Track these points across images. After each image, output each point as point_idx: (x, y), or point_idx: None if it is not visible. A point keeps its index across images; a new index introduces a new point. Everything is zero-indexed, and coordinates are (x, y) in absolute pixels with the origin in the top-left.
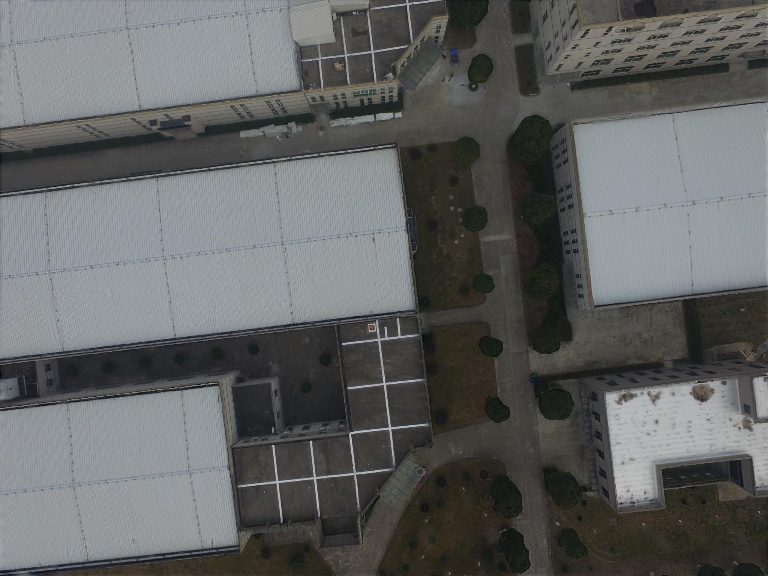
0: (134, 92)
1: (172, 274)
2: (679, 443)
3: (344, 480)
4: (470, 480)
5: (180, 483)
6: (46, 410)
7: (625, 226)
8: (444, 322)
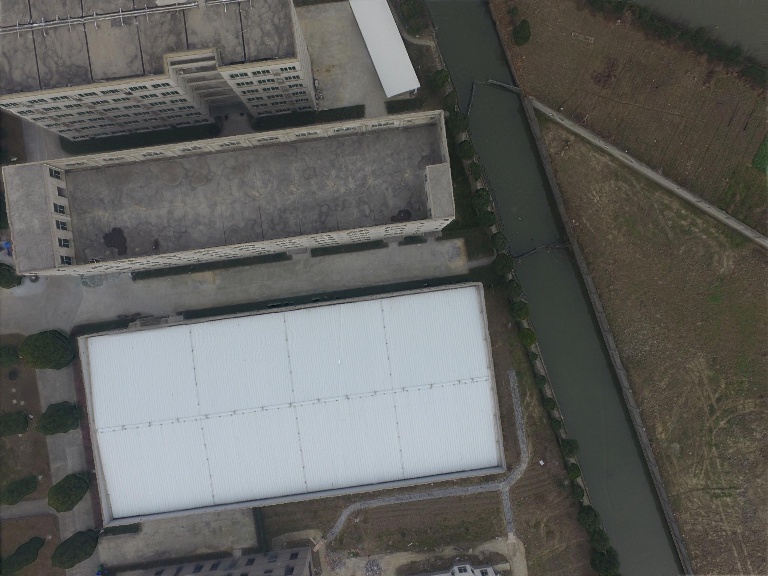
0: None
1: None
2: None
3: None
4: None
5: None
6: None
7: (139, 440)
8: (11, 515)
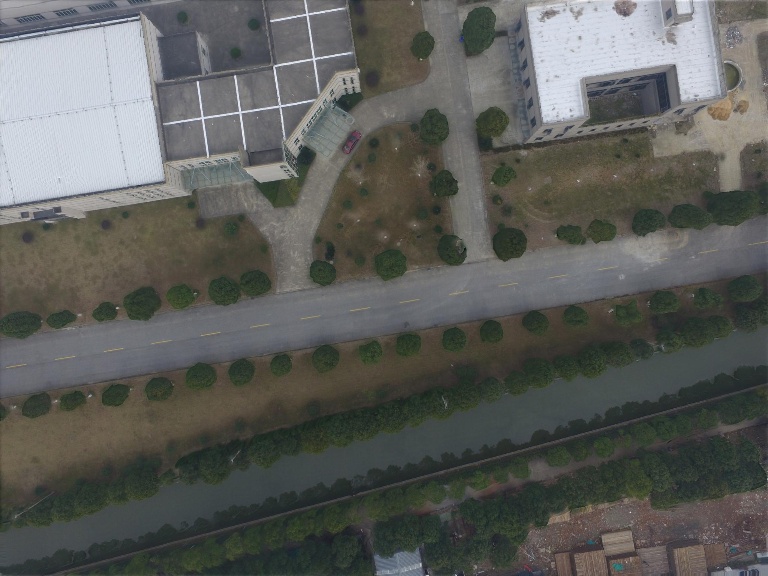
0: None
1: None
2: (603, 58)
3: (269, 113)
4: (403, 141)
5: (104, 117)
6: None
7: None
8: None
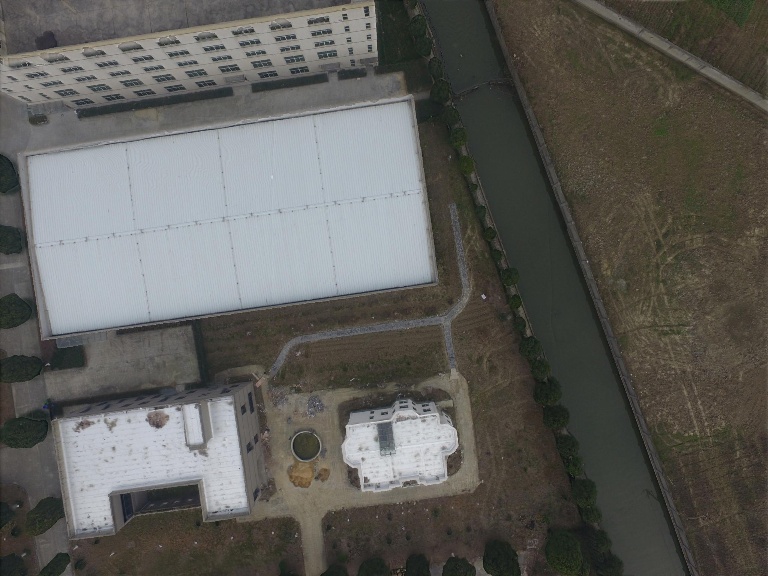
0: None
1: None
2: (136, 469)
3: None
4: None
5: None
6: None
7: (77, 256)
8: None
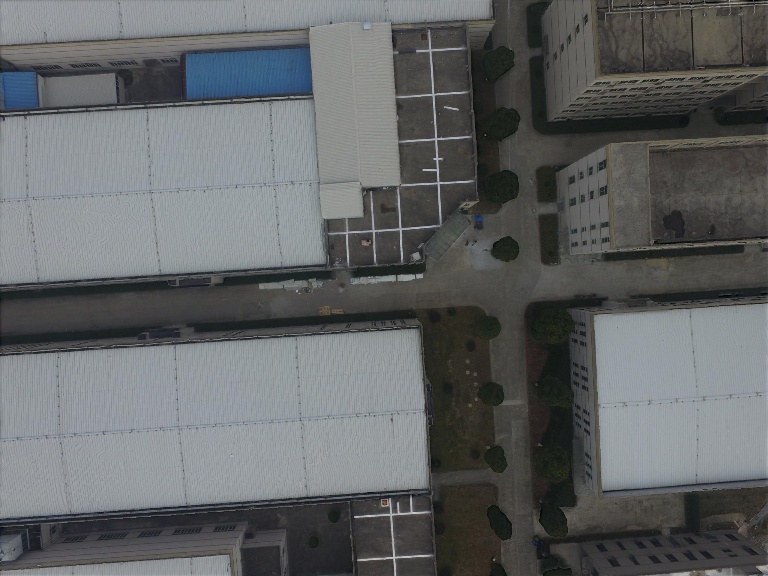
0: (154, 253)
1: (186, 444)
2: None
3: None
4: None
5: None
6: (50, 572)
7: (637, 417)
8: (453, 483)
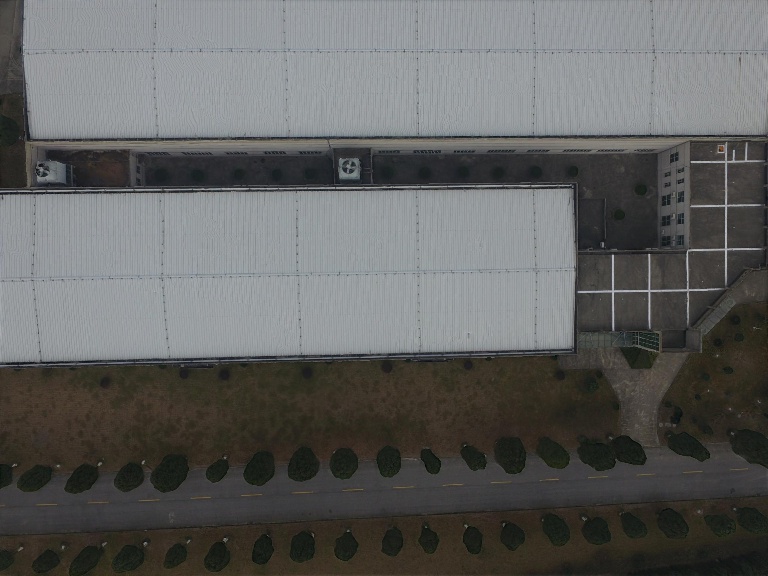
0: None
1: (540, 69)
2: None
3: (677, 295)
4: (761, 321)
5: (525, 280)
6: (394, 195)
7: None
8: None
